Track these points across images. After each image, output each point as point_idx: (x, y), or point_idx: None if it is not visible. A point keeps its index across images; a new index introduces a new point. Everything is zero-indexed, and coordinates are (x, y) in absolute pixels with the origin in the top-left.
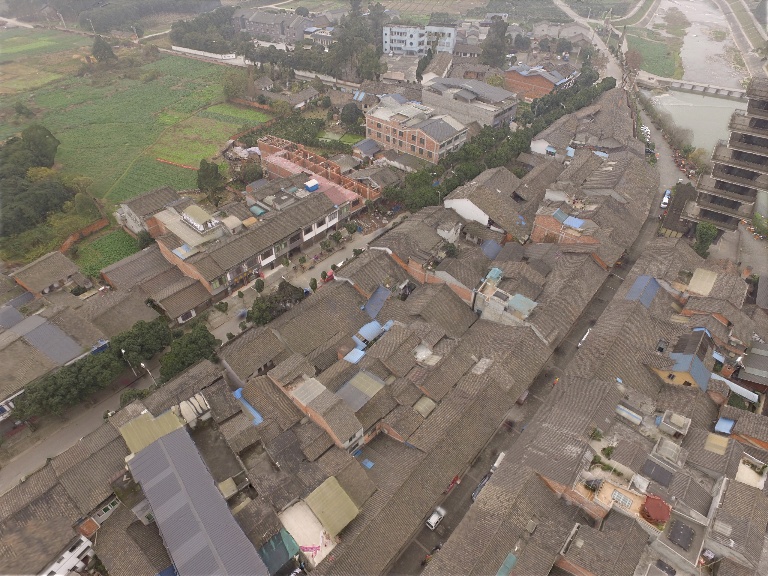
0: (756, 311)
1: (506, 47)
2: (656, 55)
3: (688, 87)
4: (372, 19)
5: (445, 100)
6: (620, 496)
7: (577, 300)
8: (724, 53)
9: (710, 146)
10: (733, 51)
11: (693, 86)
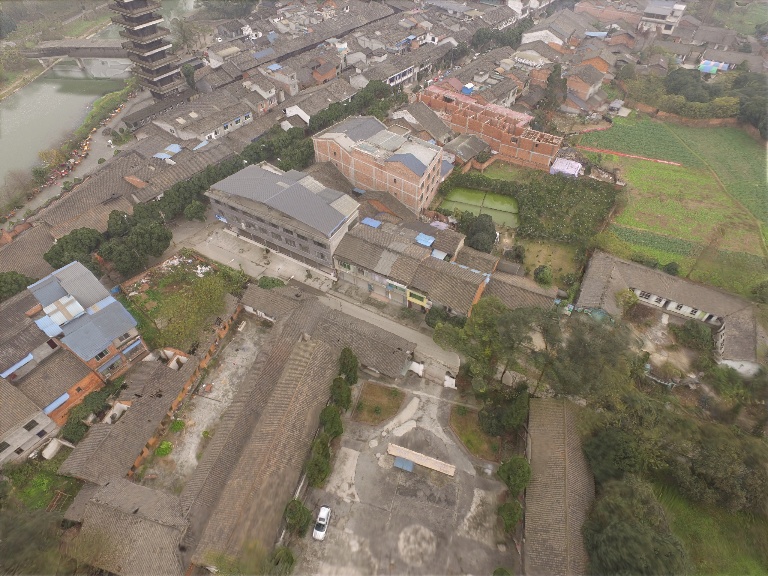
0: None
1: None
2: None
3: None
4: None
5: None
6: (327, 13)
7: None
8: None
9: None
10: None
11: None
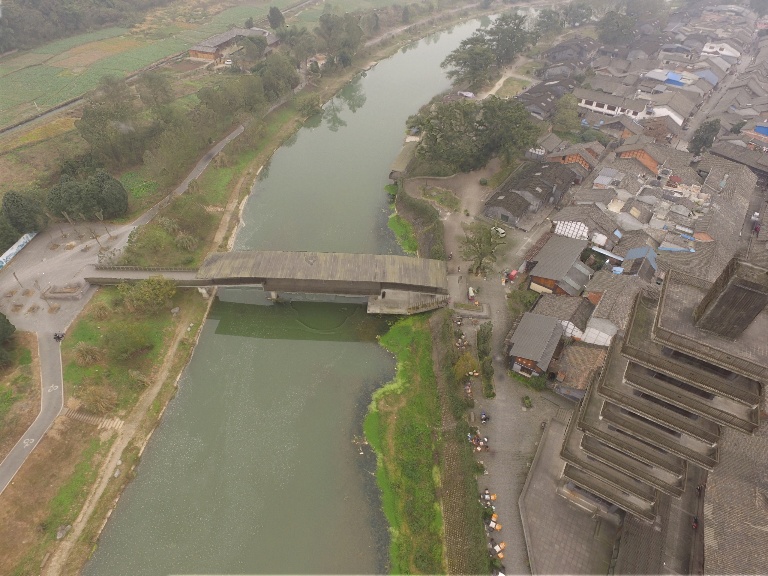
0: None
1: None
2: None
3: None
4: None
5: None
6: None
7: None
8: None
9: None
10: None
11: None
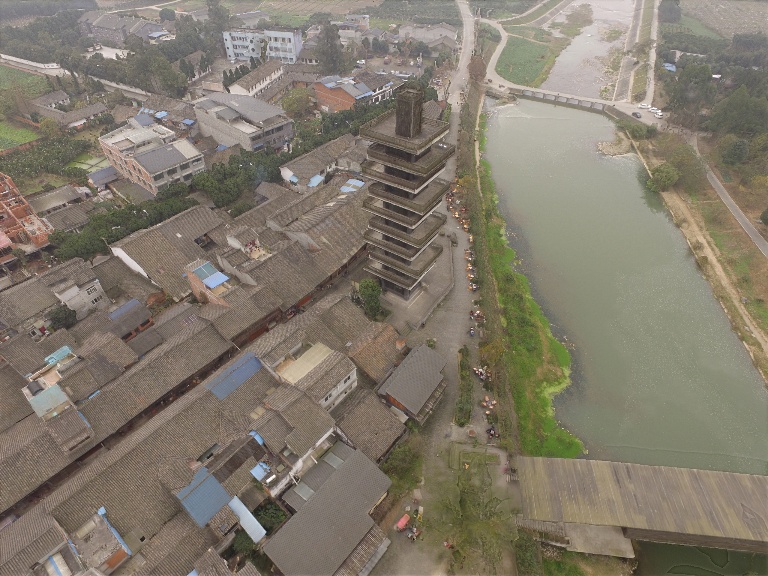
0: (365, 399)
1: (341, 54)
2: (528, 58)
3: (539, 95)
4: (214, 23)
5: (212, 119)
6: None
7: (156, 386)
8: (606, 55)
9: (516, 167)
10: (617, 53)
11: (544, 94)
